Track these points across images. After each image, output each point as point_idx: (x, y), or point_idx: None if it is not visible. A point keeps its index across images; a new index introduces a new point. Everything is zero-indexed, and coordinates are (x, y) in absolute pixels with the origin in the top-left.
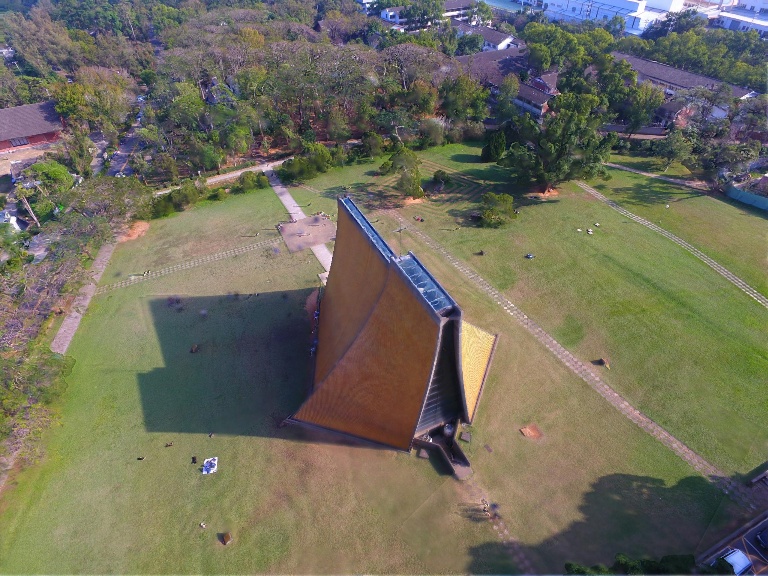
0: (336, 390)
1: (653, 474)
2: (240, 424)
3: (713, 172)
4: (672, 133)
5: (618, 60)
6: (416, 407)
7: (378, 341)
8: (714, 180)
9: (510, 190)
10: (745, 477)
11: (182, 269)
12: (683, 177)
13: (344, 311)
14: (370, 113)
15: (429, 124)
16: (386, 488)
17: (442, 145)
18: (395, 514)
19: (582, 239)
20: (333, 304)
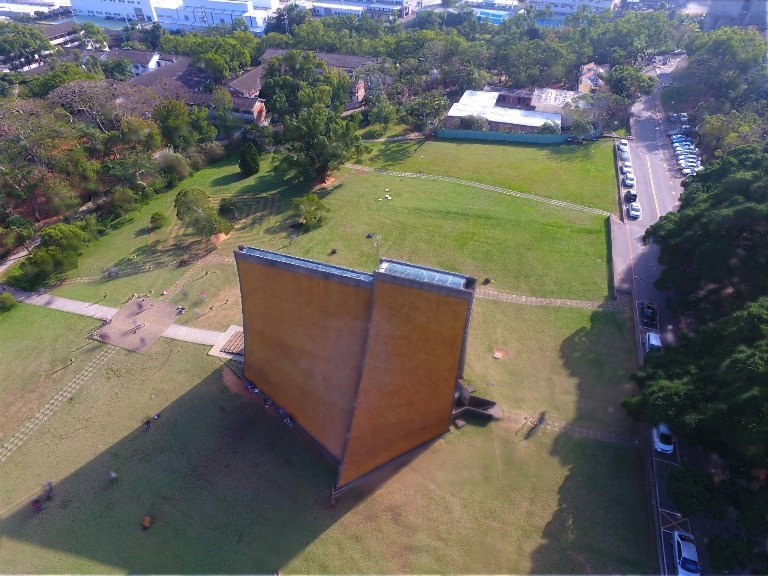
0: (367, 428)
1: (577, 327)
2: (295, 538)
3: (425, 123)
4: (378, 103)
5: (305, 54)
6: (451, 386)
7: (390, 355)
8: (426, 128)
9: (296, 191)
10: (609, 296)
11: (2, 462)
12: (401, 134)
13: (308, 359)
14: (93, 168)
15: (167, 159)
16: (464, 469)
17: (190, 176)
18: (489, 479)
19: (389, 205)
20: (281, 363)
